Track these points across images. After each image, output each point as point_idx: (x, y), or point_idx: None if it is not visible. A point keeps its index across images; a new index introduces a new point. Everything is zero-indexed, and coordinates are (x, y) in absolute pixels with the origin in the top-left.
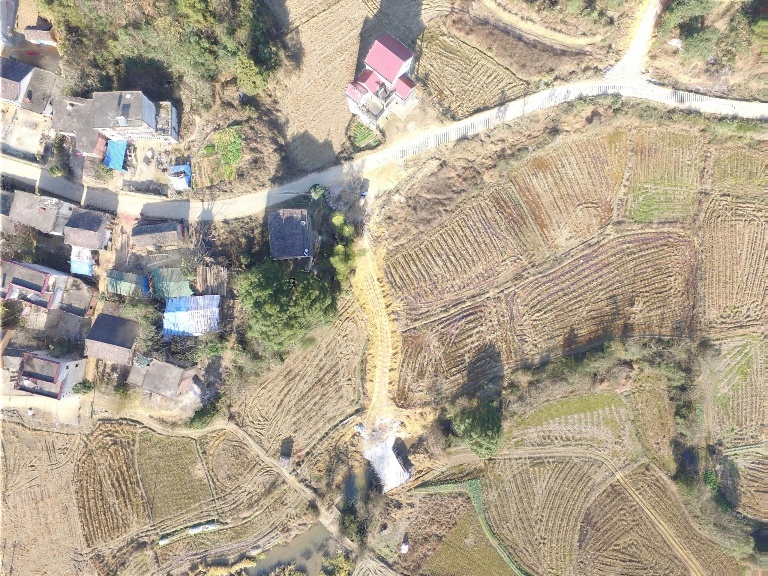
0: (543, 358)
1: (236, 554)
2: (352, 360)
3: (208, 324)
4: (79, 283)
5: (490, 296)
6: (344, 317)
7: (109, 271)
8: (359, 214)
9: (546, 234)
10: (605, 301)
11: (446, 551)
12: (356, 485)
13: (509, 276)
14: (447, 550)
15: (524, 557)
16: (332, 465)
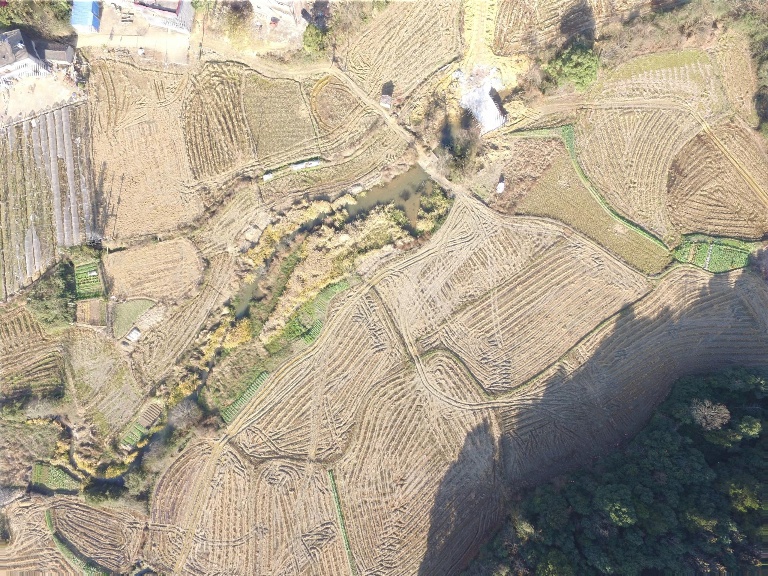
0: (633, 13)
1: (337, 192)
2: (450, 12)
3: None
4: None
5: None
6: None
7: None
8: None
9: None
10: None
11: (540, 191)
12: (452, 134)
13: None
14: (541, 190)
15: (615, 199)
16: (431, 109)
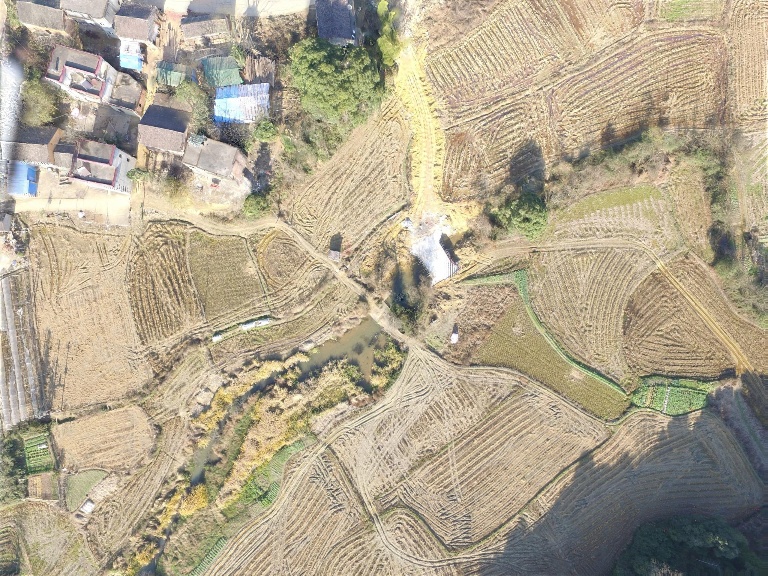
0: (583, 152)
1: (289, 349)
2: (397, 158)
3: (258, 111)
4: (128, 78)
5: (529, 94)
6: (388, 117)
7: (159, 62)
8: (400, 14)
9: (581, 33)
10: (640, 96)
11: (495, 339)
12: (404, 282)
13: (547, 74)
14: (496, 339)
15: (571, 344)
16: (381, 260)
